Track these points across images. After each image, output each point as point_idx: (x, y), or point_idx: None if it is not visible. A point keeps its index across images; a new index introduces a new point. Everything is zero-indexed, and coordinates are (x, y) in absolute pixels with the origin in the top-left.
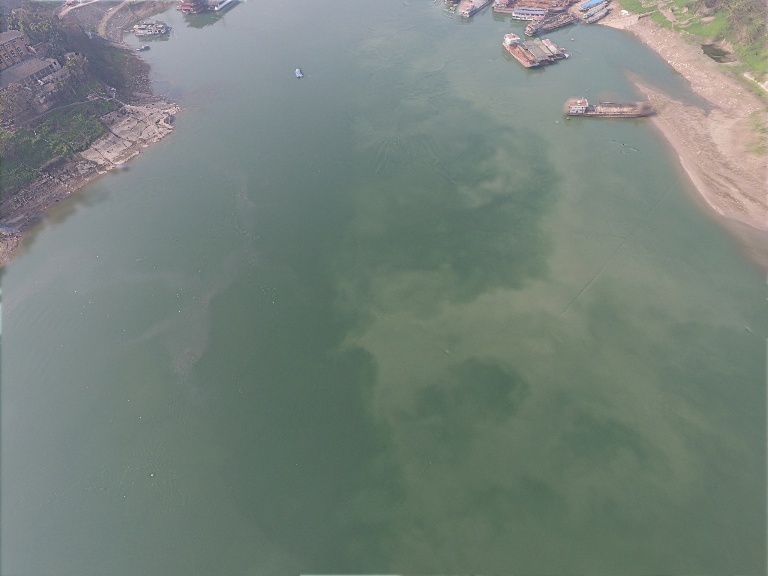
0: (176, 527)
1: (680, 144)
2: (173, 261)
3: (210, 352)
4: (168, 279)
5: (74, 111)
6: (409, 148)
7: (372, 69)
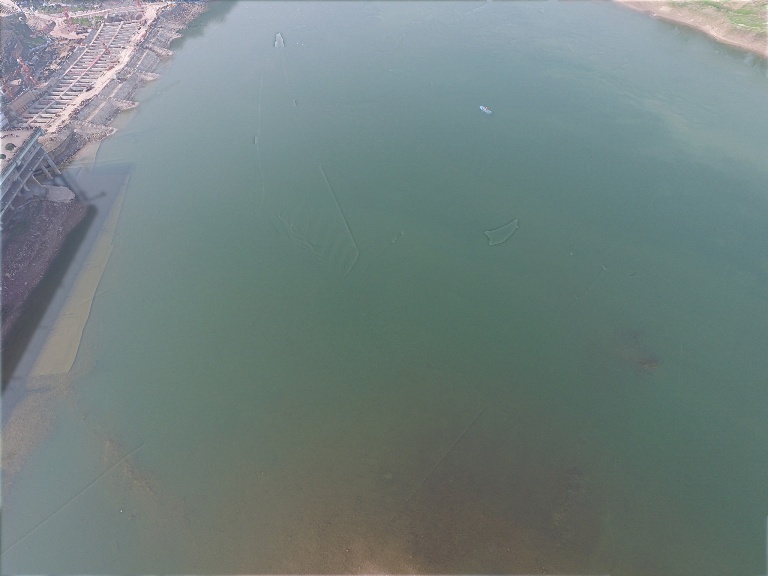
0: (310, 51)
1: None
2: (285, 7)
3: (311, 24)
4: None
5: None
6: None
7: None
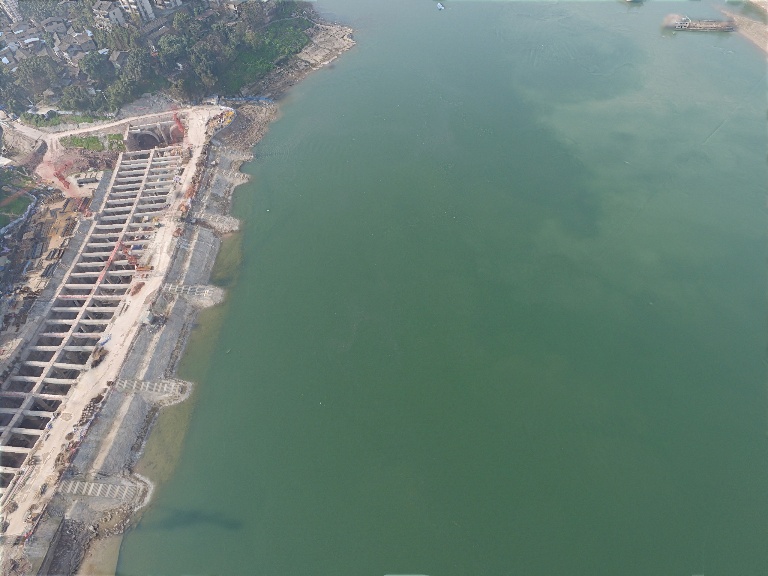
0: (483, 239)
1: (767, 47)
2: (403, 117)
3: (459, 162)
4: (404, 127)
5: (287, 24)
6: (555, 51)
7: (502, 2)
